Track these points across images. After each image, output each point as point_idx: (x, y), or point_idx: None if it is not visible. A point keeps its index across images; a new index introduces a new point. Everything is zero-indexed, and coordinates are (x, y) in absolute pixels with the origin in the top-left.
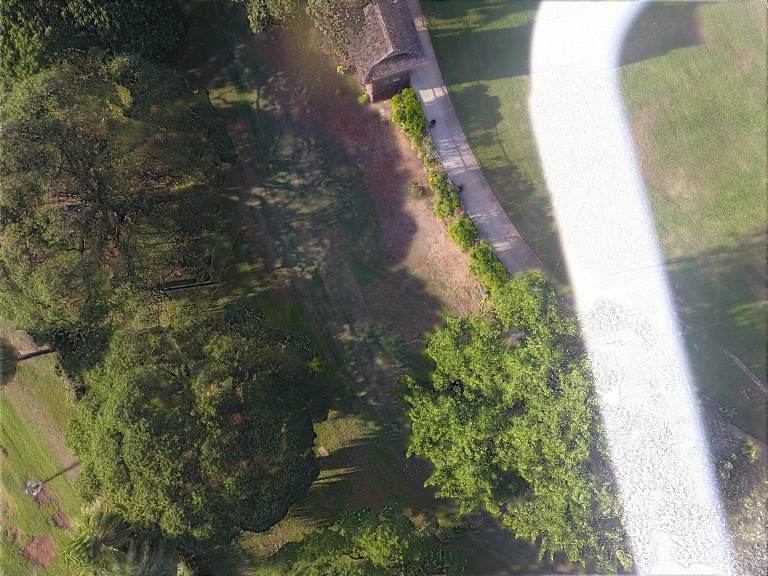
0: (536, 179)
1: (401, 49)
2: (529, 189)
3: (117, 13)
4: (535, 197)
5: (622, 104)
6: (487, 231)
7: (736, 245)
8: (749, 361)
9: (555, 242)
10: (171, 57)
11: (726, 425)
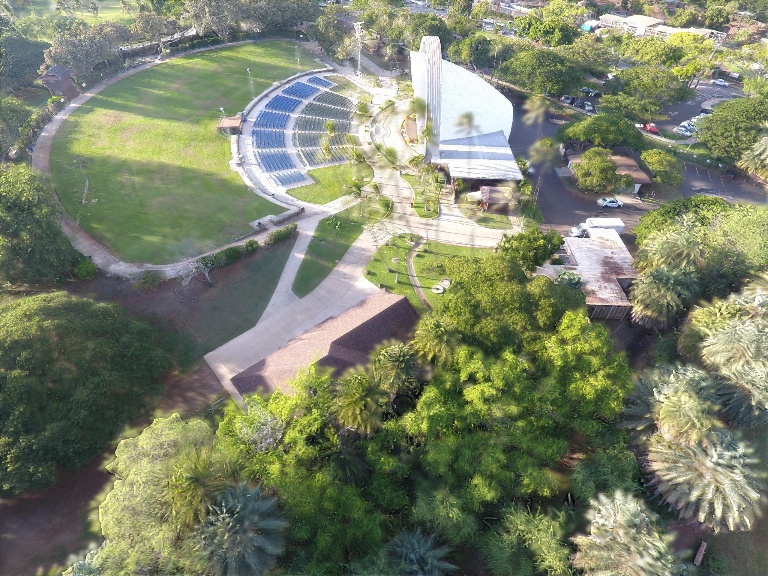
0: (81, 126)
1: (52, 73)
2: (74, 127)
3: (6, 70)
4: (74, 129)
5: (135, 122)
6: (45, 130)
7: (133, 159)
8: (92, 183)
9: (64, 138)
10: (15, 88)
11: (6, 125)
